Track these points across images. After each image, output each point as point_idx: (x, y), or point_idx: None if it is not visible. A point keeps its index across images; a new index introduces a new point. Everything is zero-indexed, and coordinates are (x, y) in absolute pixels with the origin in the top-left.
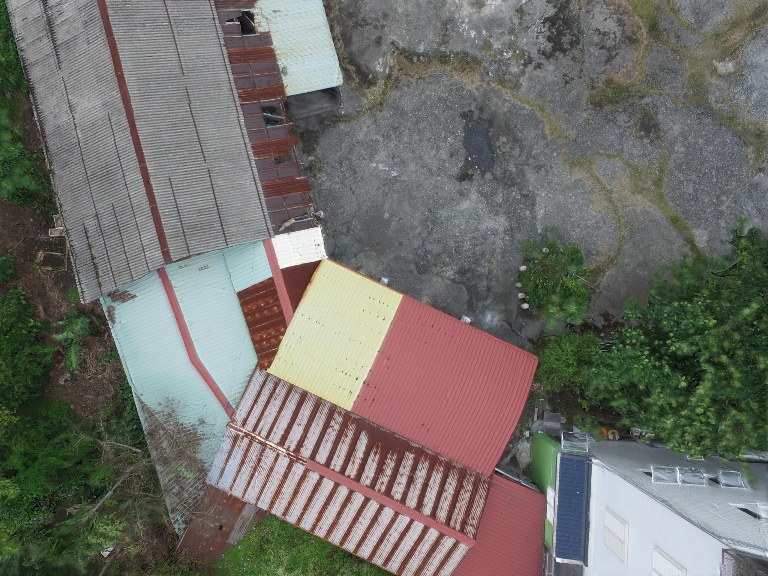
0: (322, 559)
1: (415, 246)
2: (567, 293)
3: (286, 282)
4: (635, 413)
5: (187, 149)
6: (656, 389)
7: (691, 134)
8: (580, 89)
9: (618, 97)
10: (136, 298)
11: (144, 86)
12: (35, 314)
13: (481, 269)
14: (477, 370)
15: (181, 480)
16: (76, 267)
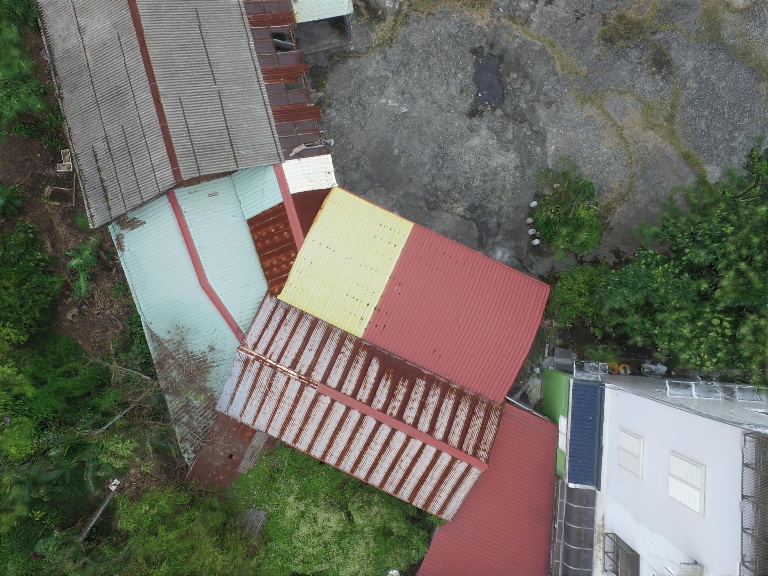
0: (332, 490)
1: (425, 182)
2: (579, 222)
3: (297, 207)
4: (650, 332)
5: (197, 70)
6: (672, 300)
7: (703, 70)
8: (591, 25)
9: (629, 33)
10: (145, 224)
11: (154, 5)
12: (43, 249)
13: (491, 205)
14: (489, 296)
15: (191, 409)
16: (85, 191)
